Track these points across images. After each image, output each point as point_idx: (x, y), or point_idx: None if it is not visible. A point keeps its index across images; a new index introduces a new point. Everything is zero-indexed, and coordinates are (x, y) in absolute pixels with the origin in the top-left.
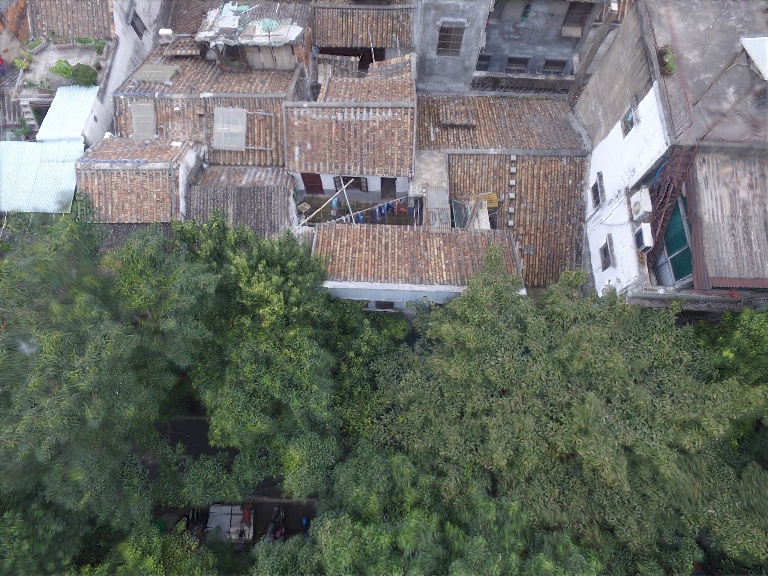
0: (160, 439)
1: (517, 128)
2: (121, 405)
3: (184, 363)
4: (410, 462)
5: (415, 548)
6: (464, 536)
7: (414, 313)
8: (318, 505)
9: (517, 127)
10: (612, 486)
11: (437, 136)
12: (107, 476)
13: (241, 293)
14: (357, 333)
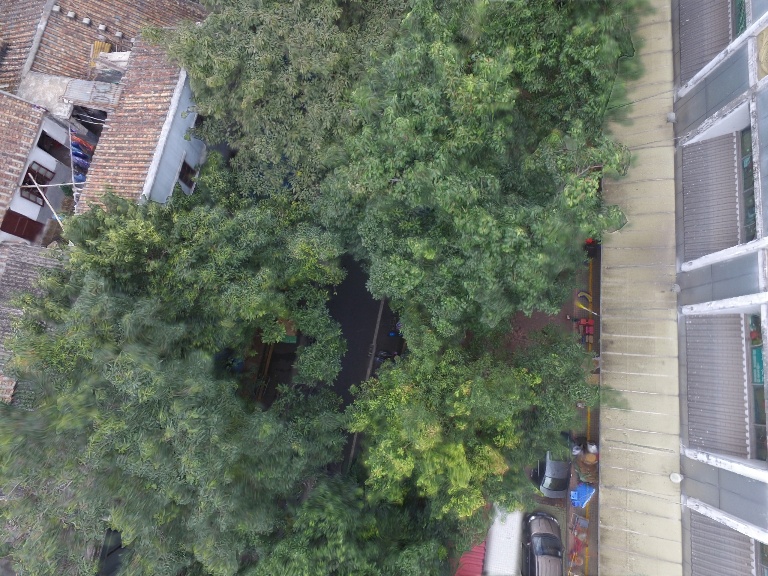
0: (270, 410)
1: (24, 4)
2: (212, 412)
3: (179, 331)
4: (329, 148)
5: (378, 108)
6: (386, 93)
7: (205, 154)
8: (357, 256)
9: (23, 4)
10: (382, 3)
11: (5, 81)
12: (281, 426)
13: (118, 269)
14: (207, 200)
